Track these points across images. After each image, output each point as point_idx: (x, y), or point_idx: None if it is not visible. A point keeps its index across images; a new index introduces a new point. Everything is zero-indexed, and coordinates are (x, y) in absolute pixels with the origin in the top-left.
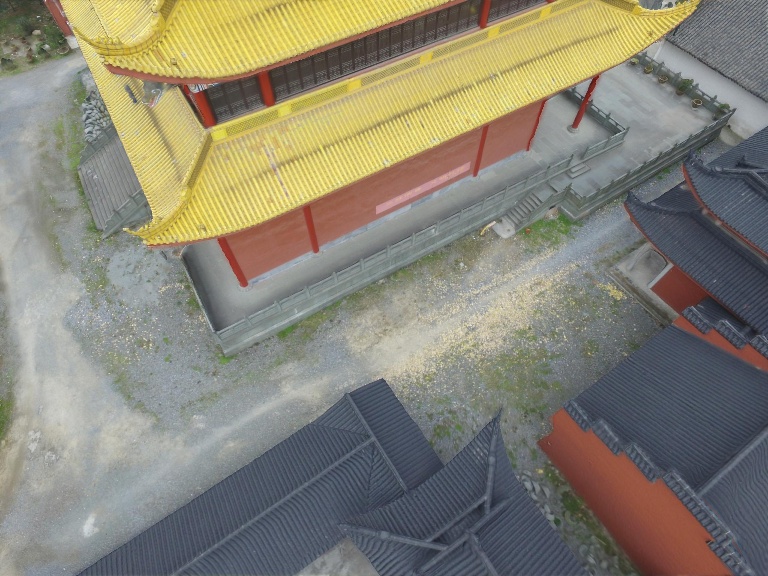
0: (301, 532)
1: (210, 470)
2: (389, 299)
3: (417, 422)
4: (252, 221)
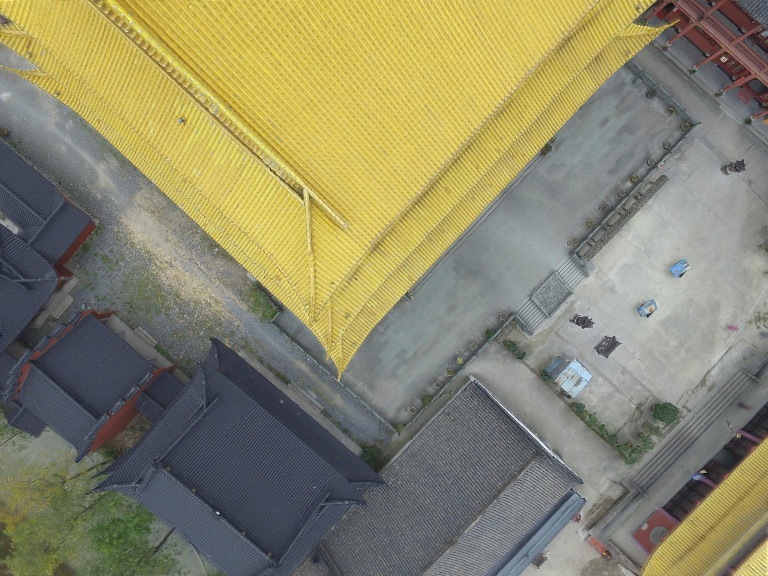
0: (3, 201)
1: (48, 142)
2: (176, 208)
3: (106, 245)
4: (83, 116)
